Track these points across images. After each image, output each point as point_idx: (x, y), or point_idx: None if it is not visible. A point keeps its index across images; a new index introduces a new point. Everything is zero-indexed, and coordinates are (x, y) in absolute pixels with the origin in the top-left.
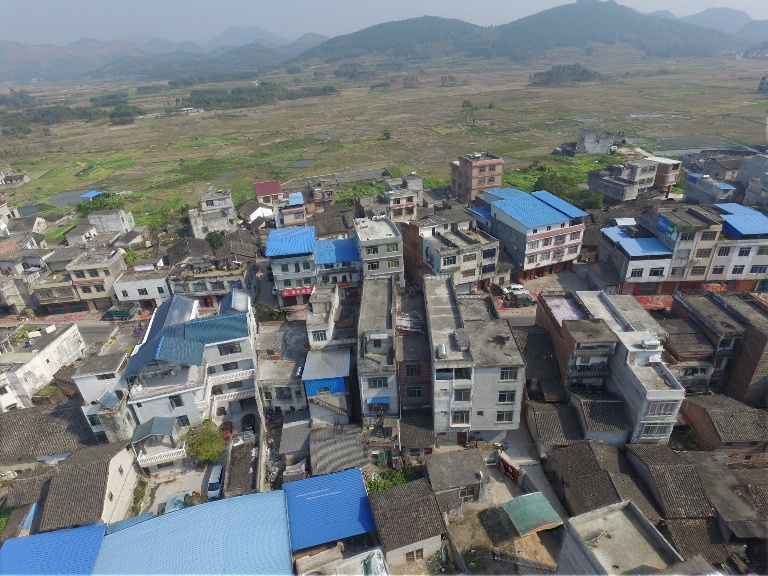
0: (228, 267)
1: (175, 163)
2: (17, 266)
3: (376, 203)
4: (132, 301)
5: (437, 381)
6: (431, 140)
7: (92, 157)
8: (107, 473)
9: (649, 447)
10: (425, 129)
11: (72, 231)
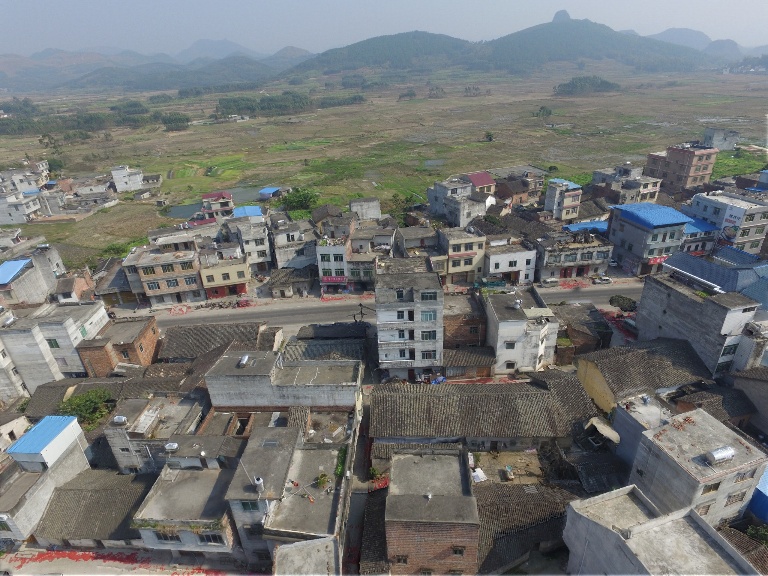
0: (585, 240)
1: (297, 163)
2: (369, 244)
3: (621, 188)
4: (497, 273)
5: None
6: (534, 141)
7: (194, 159)
8: None
9: None
10: (512, 132)
11: None
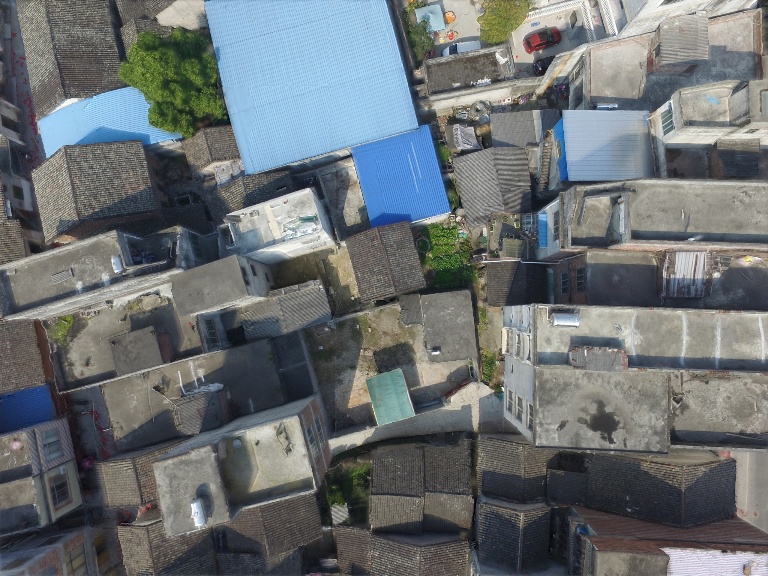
0: None
1: None
2: None
3: None
4: None
5: (528, 309)
6: None
7: None
8: None
9: (461, 567)
10: None
11: None
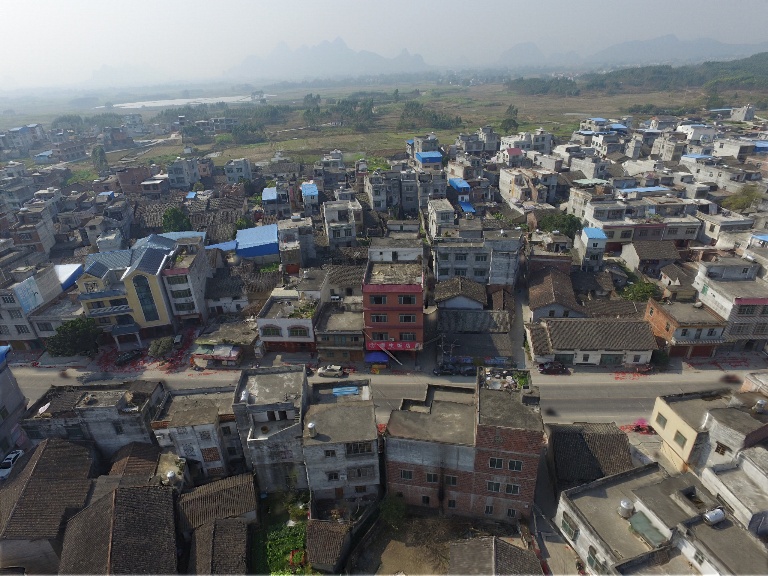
0: None
1: None
2: None
3: None
4: None
5: None
6: None
7: None
8: None
9: None
10: None
11: None
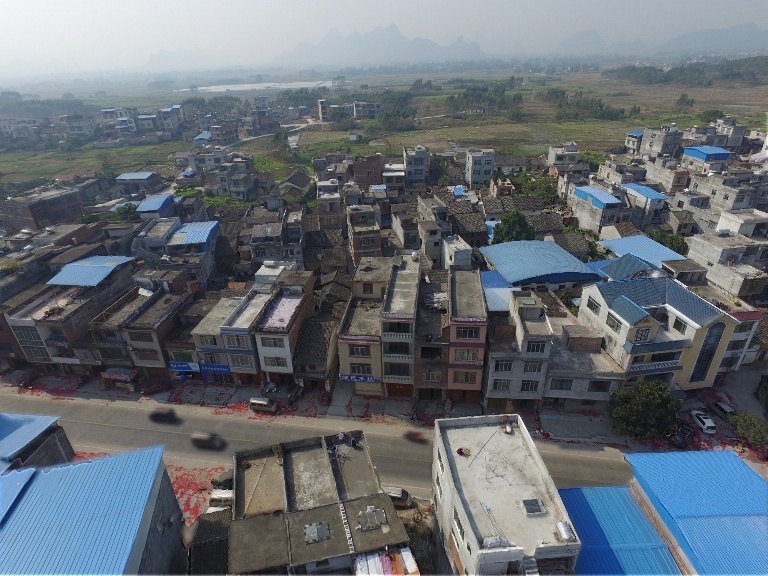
0: None
1: None
2: None
3: None
4: None
5: None
6: None
7: None
8: None
9: None
10: None
11: None
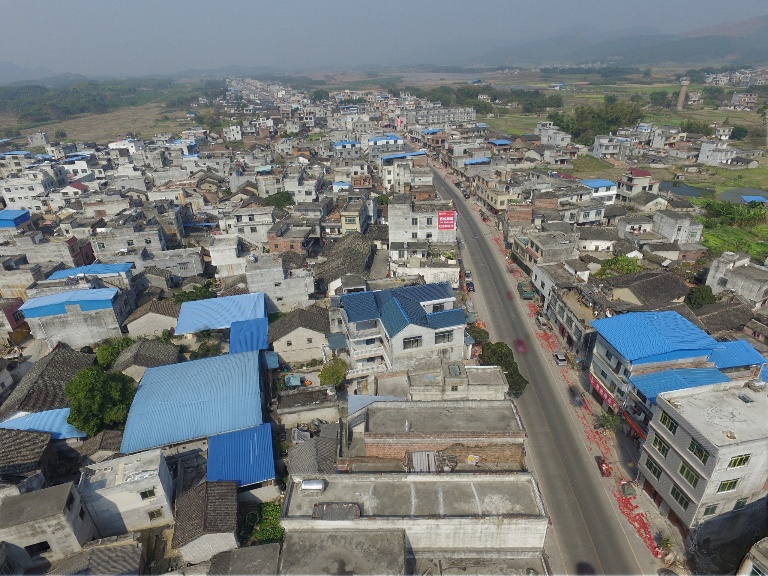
0: None
1: None
2: (537, 219)
3: None
4: None
5: None
6: None
7: None
8: (290, 329)
9: None
10: None
11: (630, 217)
